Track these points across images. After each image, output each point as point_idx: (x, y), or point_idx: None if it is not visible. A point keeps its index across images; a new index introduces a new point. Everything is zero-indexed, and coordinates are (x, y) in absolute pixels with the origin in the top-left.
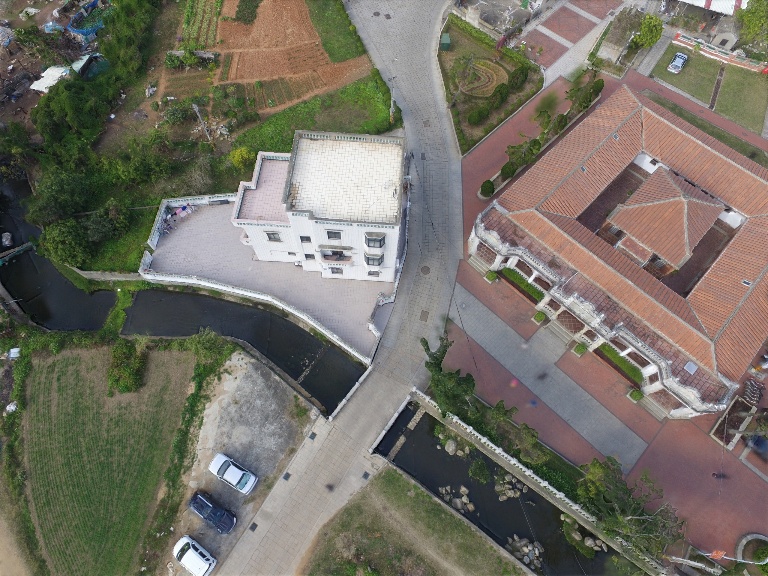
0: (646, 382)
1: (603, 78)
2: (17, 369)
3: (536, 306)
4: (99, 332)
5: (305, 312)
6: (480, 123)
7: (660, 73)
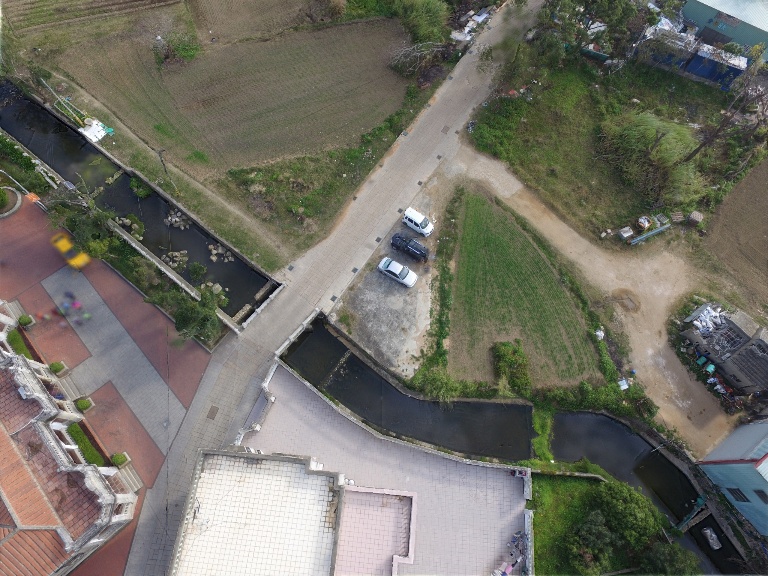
0: (8, 328)
1: None
2: (611, 366)
3: (83, 418)
4: (554, 408)
5: (342, 421)
6: None
7: None
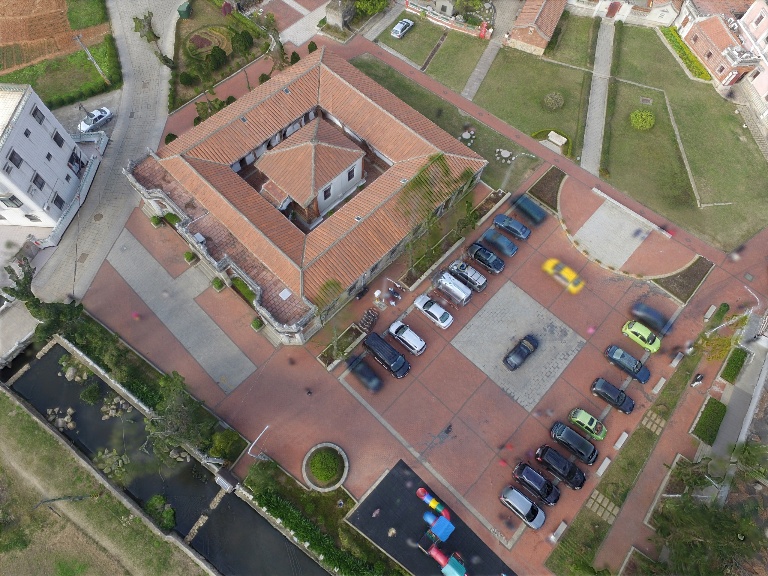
0: None
1: (329, 43)
2: None
3: (190, 247)
4: None
5: None
6: (196, 84)
7: (385, 38)
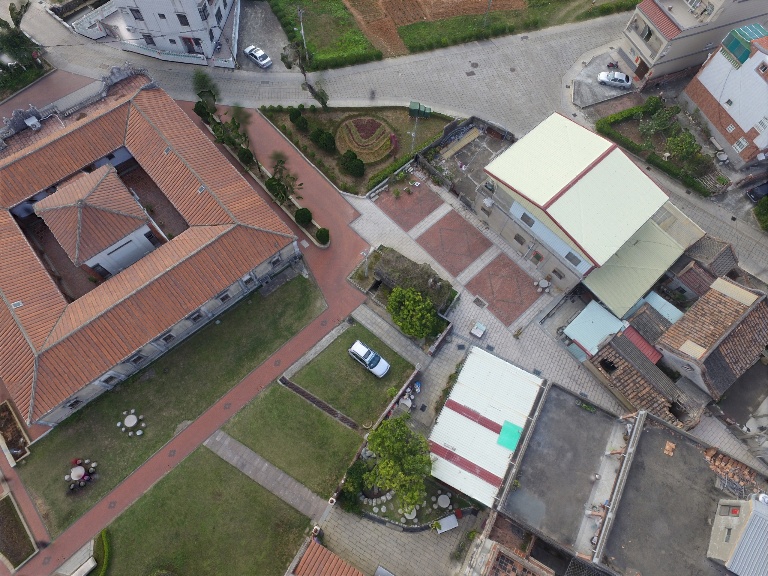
0: None
1: (353, 260)
2: None
3: None
4: None
5: None
6: None
7: (356, 334)
